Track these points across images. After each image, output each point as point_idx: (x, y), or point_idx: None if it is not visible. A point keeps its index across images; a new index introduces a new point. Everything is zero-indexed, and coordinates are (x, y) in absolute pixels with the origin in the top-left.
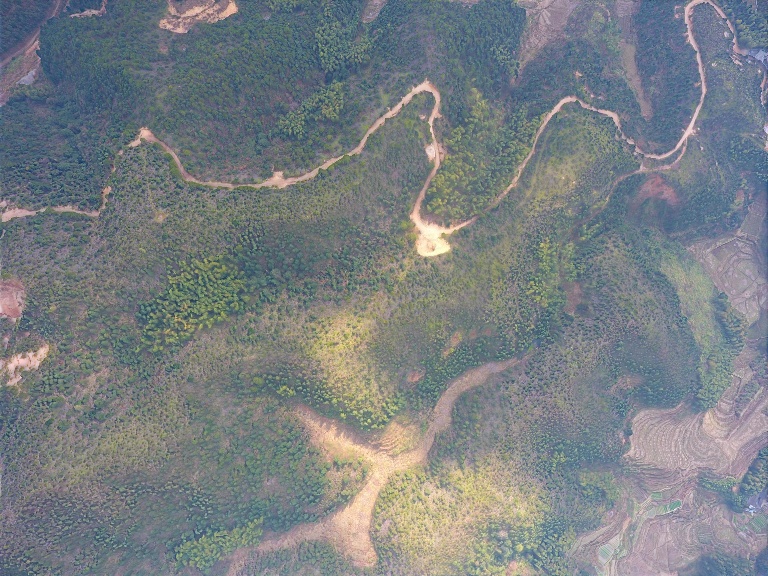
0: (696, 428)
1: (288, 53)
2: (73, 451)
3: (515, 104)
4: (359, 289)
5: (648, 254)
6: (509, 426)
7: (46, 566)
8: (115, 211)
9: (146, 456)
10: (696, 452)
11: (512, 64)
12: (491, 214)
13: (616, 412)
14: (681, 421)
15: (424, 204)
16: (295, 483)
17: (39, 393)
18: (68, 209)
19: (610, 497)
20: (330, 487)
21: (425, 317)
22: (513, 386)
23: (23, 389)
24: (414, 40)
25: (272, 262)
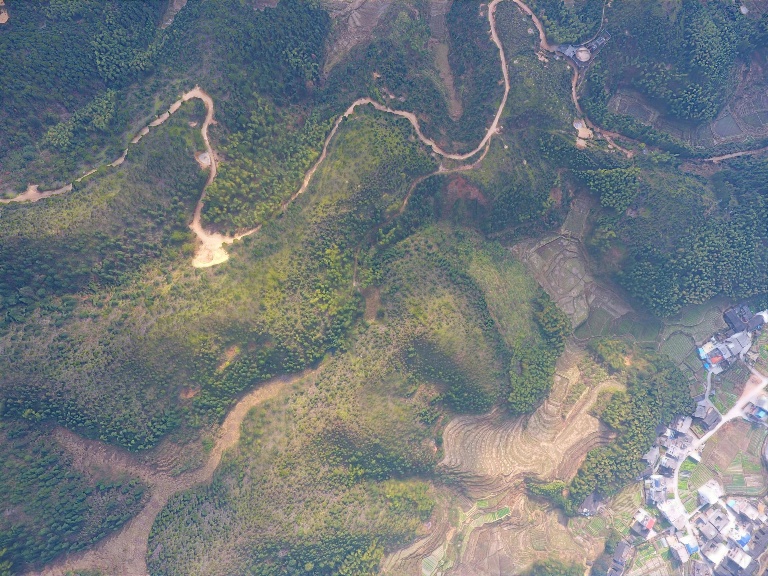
0: (519, 432)
1: (55, 62)
2: None
3: (315, 108)
4: (120, 304)
5: (456, 256)
6: (290, 440)
7: None
8: None
9: None
10: (520, 457)
11: (309, 67)
12: (274, 221)
13: (419, 420)
14: (501, 426)
15: (204, 213)
16: (44, 511)
17: None
18: None
19: (420, 508)
20: (91, 513)
21: (185, 331)
22: (301, 398)
23: None
24: (193, 45)
25: (19, 280)
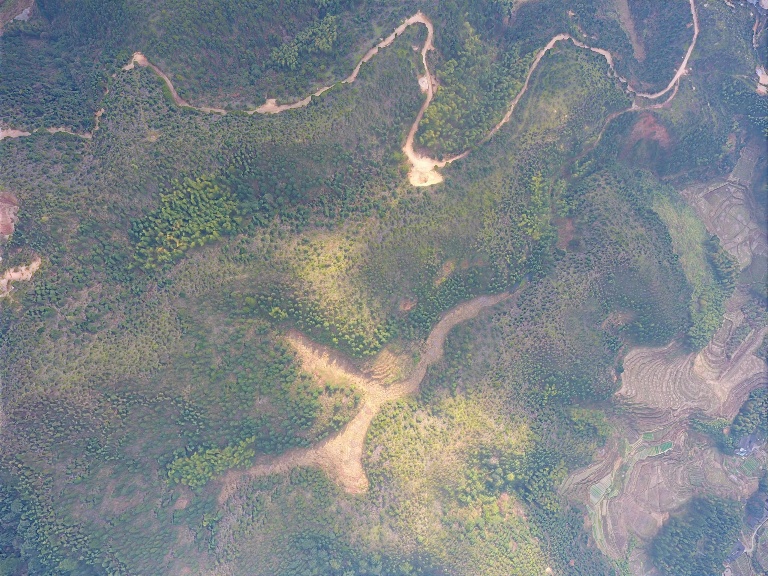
0: (687, 369)
1: None
2: (65, 359)
3: (508, 44)
4: (351, 216)
5: (640, 194)
6: (500, 355)
7: (38, 472)
8: (108, 130)
9: (138, 365)
10: (687, 393)
11: (505, 3)
12: (483, 147)
13: (607, 347)
14: (672, 361)
15: (417, 137)
16: (287, 404)
17: (31, 303)
18: (61, 131)
19: (601, 433)
20: (322, 411)
21: (417, 242)
22: (505, 318)
23: (15, 298)
24: None
25: (264, 186)
